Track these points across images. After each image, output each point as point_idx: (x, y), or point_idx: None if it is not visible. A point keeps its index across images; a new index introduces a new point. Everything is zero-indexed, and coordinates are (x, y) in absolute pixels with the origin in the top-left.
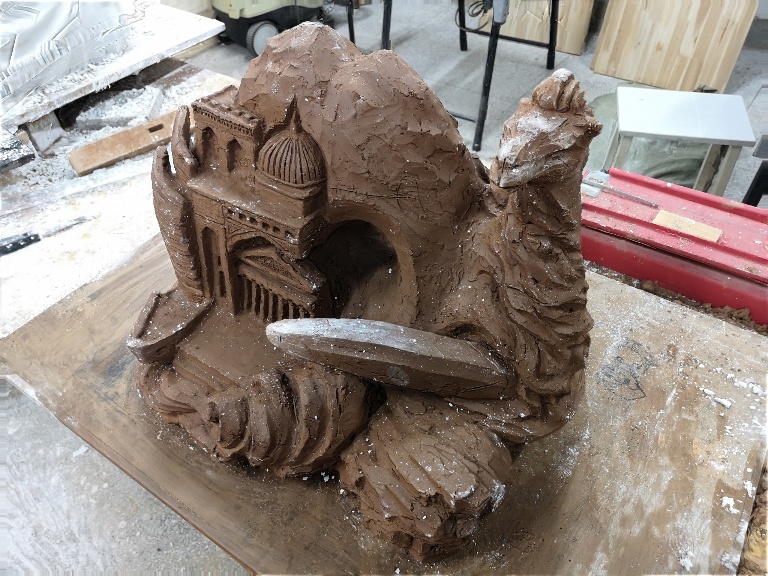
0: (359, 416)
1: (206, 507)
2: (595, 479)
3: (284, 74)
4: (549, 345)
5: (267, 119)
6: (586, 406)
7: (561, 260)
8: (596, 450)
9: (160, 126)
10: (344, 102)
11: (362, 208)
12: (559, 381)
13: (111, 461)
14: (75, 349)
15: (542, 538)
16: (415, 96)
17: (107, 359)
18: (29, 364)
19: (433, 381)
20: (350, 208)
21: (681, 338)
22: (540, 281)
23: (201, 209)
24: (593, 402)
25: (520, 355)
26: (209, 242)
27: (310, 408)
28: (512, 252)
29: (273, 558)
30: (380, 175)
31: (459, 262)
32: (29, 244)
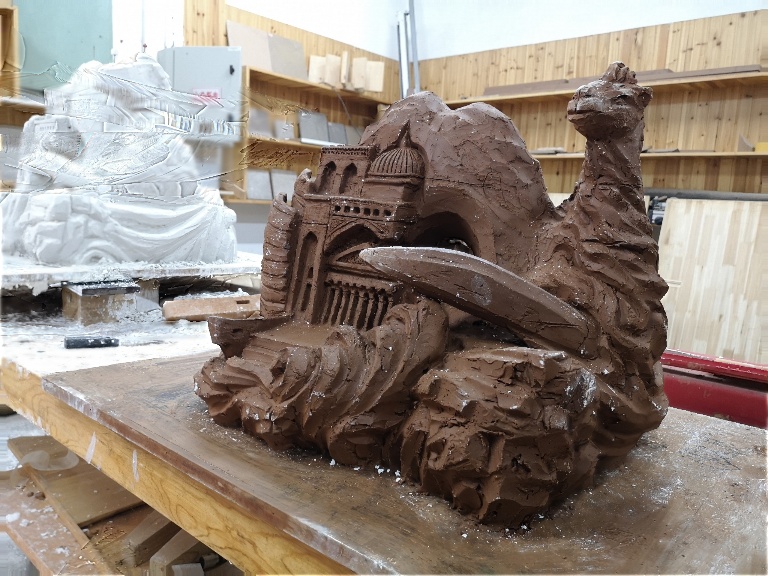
0: (437, 340)
1: (242, 471)
2: (698, 509)
3: (403, 108)
4: (627, 292)
5: (382, 145)
6: (673, 467)
7: (630, 209)
8: (693, 492)
9: (247, 302)
10: (447, 122)
11: (453, 195)
12: (641, 342)
13: (144, 444)
14: (133, 382)
15: (643, 537)
16: (502, 119)
17: (162, 390)
18: (85, 383)
19: (515, 304)
20: (442, 196)
21: (767, 444)
22: (613, 225)
23: (310, 216)
24: (680, 466)
25: (599, 302)
26: (306, 254)
27: (386, 339)
28: (586, 206)
29: (313, 510)
30: (471, 168)
31: (535, 248)
32: (107, 346)
